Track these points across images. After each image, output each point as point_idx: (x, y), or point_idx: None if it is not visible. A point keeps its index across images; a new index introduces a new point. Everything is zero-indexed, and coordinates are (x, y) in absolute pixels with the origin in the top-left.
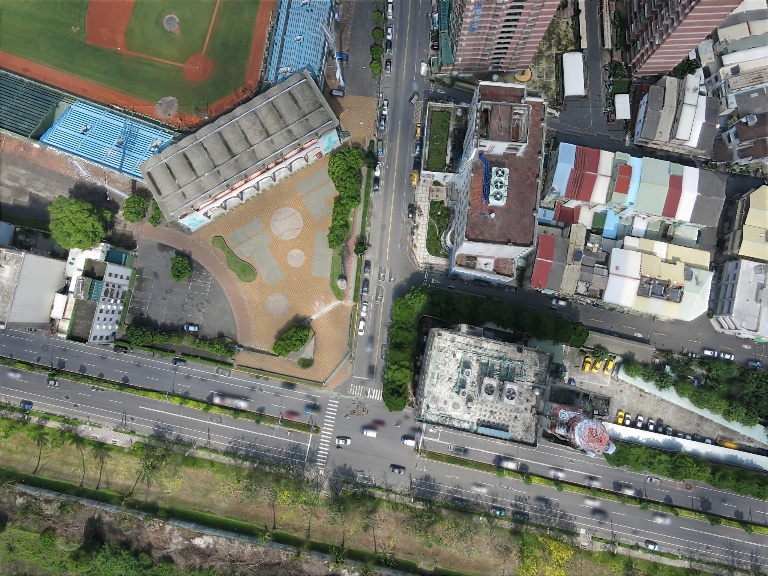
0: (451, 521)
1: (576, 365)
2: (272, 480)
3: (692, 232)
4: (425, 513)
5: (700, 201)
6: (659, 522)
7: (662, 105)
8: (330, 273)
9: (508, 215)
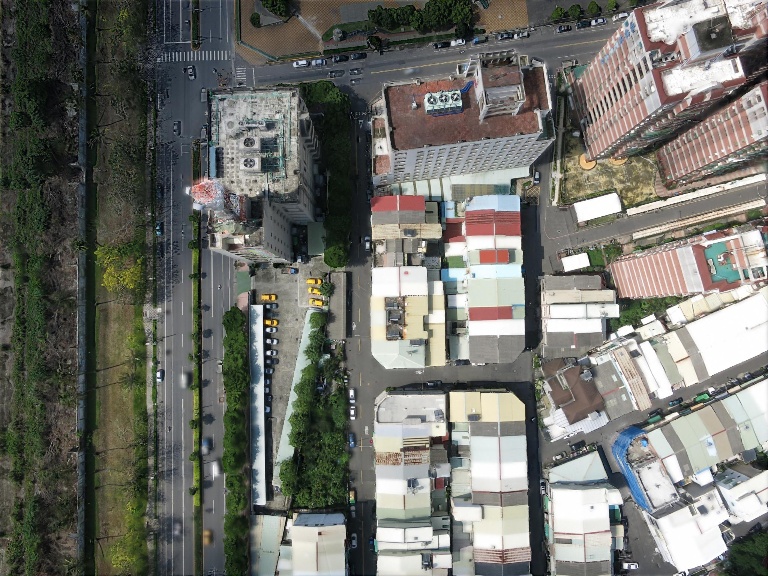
0: (137, 176)
1: (312, 272)
2: (137, 5)
3: (465, 353)
4: (138, 148)
5: (492, 340)
6: (183, 379)
7: (582, 289)
8: (346, 23)
9: (419, 122)
